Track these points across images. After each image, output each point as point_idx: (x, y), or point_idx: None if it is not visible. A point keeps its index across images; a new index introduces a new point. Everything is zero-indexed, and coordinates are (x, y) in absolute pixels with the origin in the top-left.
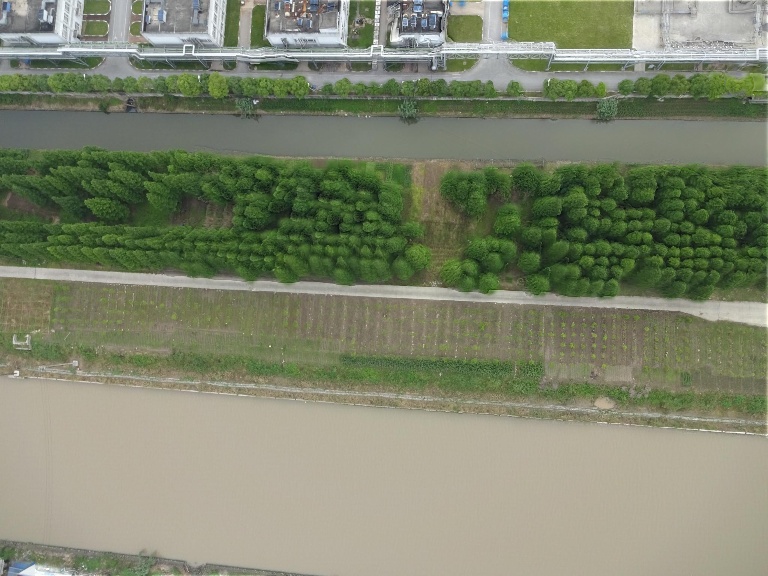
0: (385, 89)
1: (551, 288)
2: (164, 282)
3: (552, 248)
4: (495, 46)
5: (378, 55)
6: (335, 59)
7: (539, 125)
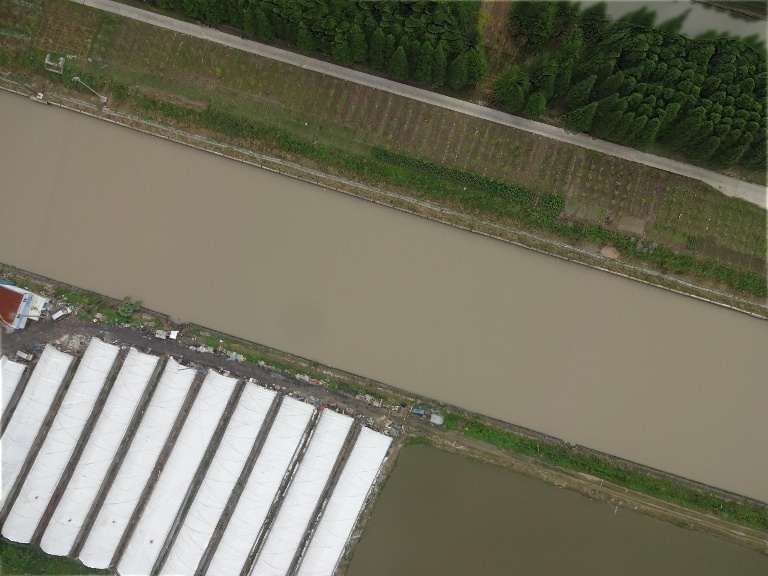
0: None
1: (592, 126)
2: (216, 38)
3: (606, 81)
4: None
5: None
6: None
7: None
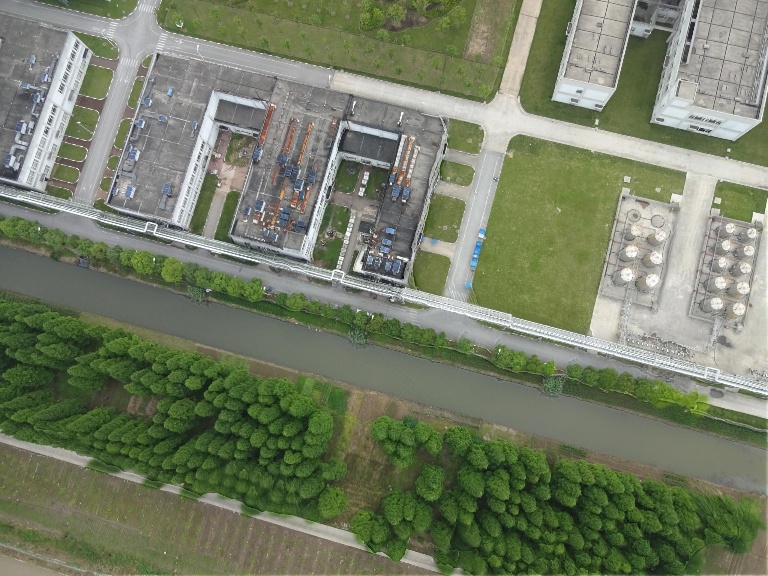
0: (339, 313)
1: None
2: (72, 458)
3: (464, 536)
4: (453, 304)
5: (338, 281)
6: (296, 271)
7: (484, 382)
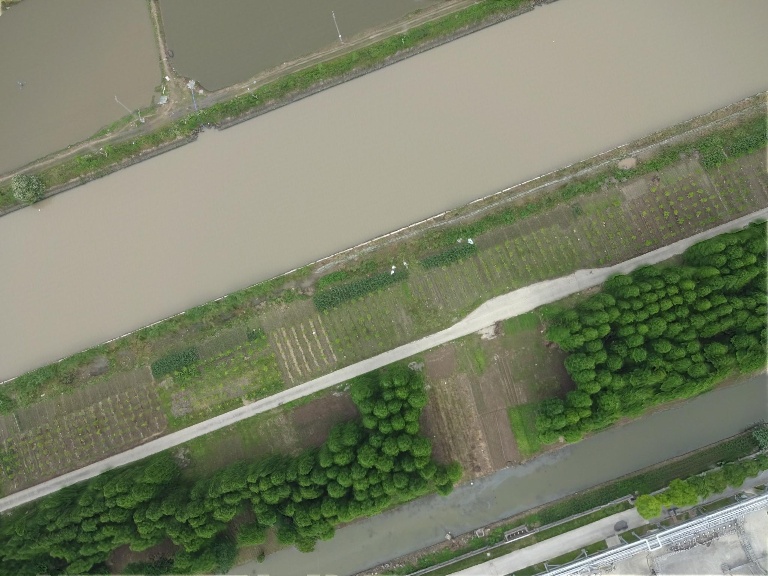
0: None
1: None
2: None
3: None
4: None
5: None
6: None
7: None
